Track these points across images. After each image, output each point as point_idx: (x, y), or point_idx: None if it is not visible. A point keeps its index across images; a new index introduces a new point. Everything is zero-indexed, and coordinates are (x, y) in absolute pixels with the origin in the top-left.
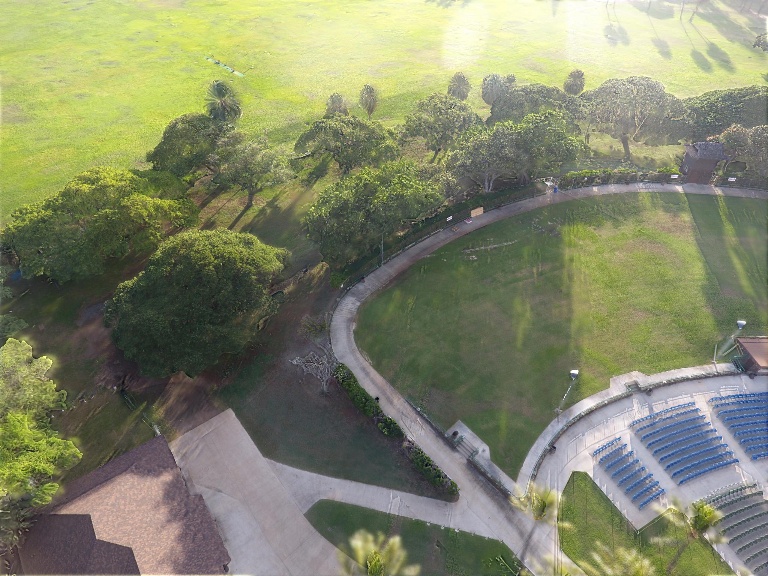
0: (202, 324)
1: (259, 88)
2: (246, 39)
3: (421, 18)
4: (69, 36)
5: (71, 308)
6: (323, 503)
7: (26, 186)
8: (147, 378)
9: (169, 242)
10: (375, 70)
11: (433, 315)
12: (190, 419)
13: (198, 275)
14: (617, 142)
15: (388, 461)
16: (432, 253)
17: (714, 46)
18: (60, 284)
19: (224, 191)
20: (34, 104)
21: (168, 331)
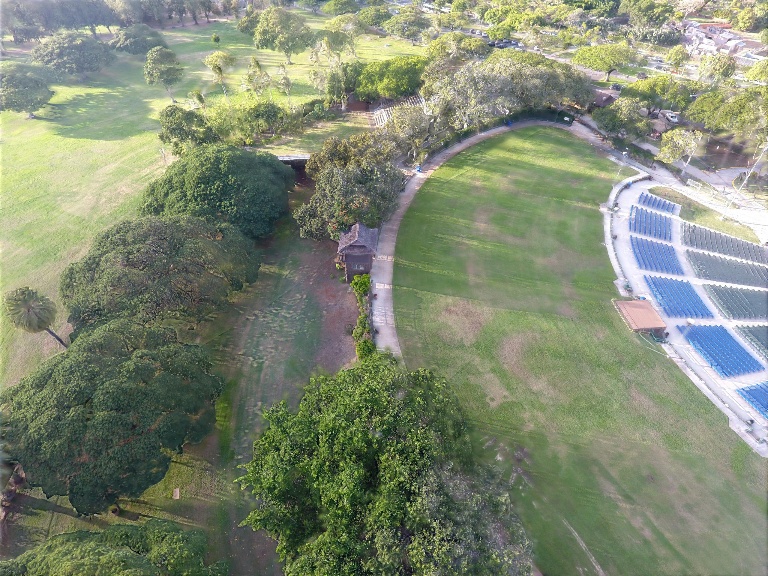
0: None
1: None
2: None
3: None
4: None
5: None
6: None
7: None
8: None
9: None
10: None
11: None
12: None
13: None
14: None
15: None
16: None
17: None
18: None
19: None
20: None
21: None
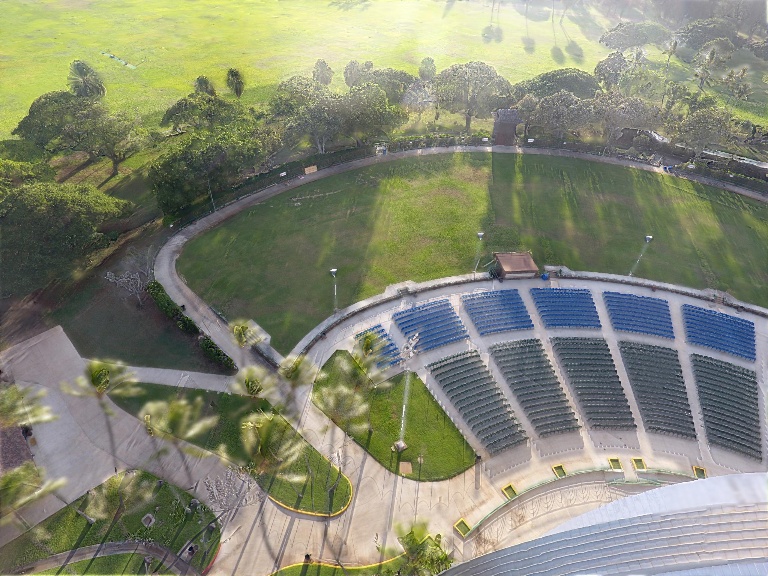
0: (32, 254)
1: (148, 78)
2: (146, 36)
3: (320, 19)
4: None
5: None
6: (124, 384)
7: None
8: None
9: None
10: (263, 63)
11: (250, 247)
12: (21, 335)
13: (30, 214)
14: (462, 119)
15: (185, 351)
16: (262, 201)
17: (573, 43)
18: None
19: (93, 163)
20: None
21: None
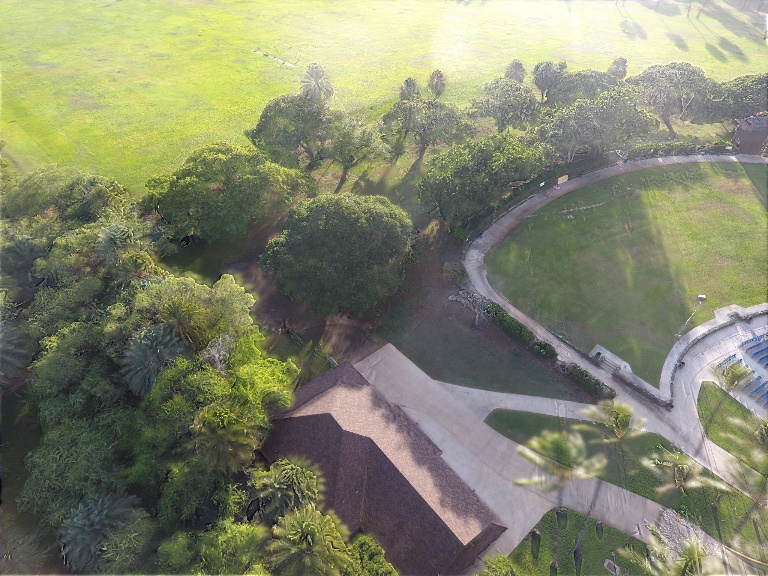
0: (362, 269)
1: None
2: (285, 33)
3: (446, 15)
4: (110, 31)
5: (212, 267)
6: (498, 411)
7: (126, 165)
8: (305, 322)
9: (308, 204)
10: (419, 61)
11: (550, 263)
12: (357, 352)
13: (353, 227)
14: None
15: (546, 377)
16: (533, 213)
17: (724, 40)
18: (209, 243)
19: (316, 167)
20: (102, 93)
21: (334, 275)
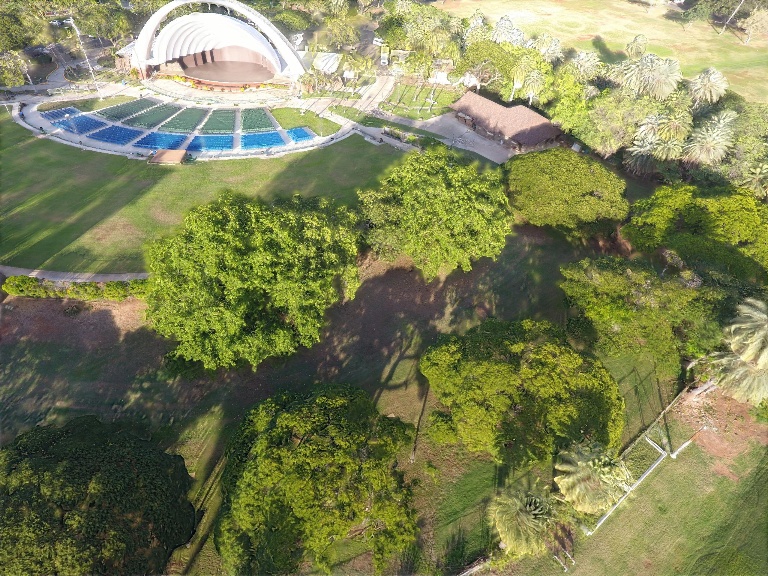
0: None
1: None
2: None
3: None
4: None
5: None
6: (441, 138)
7: None
8: None
9: None
10: None
11: None
12: None
13: None
14: None
15: None
16: None
17: None
18: None
19: None
20: None
21: None
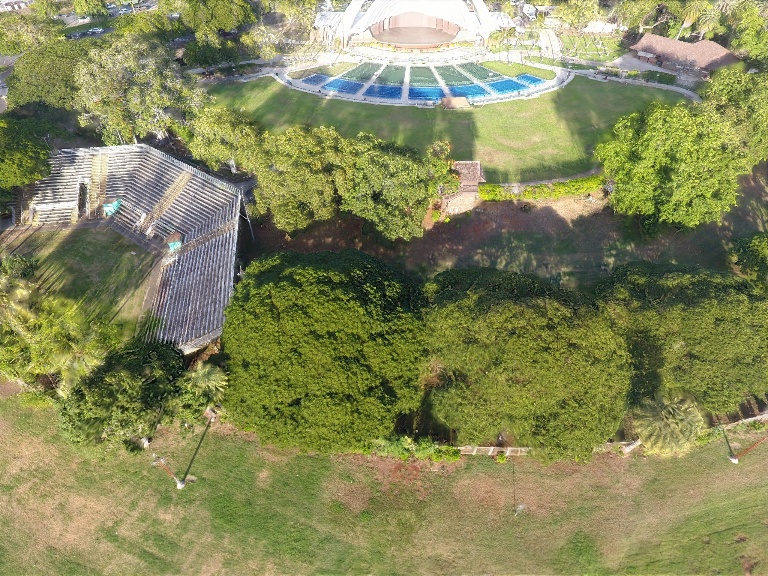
0: None
1: None
2: None
3: None
4: None
5: None
6: None
7: None
8: None
9: None
10: None
11: None
12: None
13: None
14: None
15: None
16: None
17: None
18: None
19: None
20: None
21: None
